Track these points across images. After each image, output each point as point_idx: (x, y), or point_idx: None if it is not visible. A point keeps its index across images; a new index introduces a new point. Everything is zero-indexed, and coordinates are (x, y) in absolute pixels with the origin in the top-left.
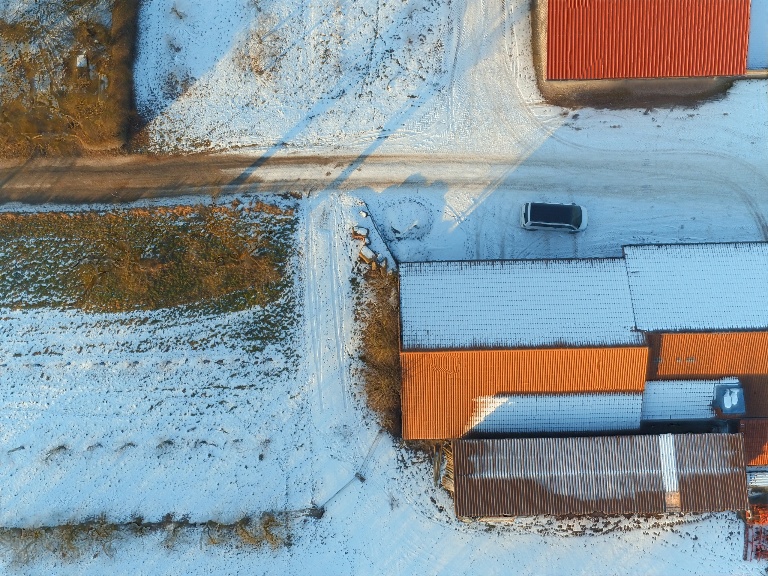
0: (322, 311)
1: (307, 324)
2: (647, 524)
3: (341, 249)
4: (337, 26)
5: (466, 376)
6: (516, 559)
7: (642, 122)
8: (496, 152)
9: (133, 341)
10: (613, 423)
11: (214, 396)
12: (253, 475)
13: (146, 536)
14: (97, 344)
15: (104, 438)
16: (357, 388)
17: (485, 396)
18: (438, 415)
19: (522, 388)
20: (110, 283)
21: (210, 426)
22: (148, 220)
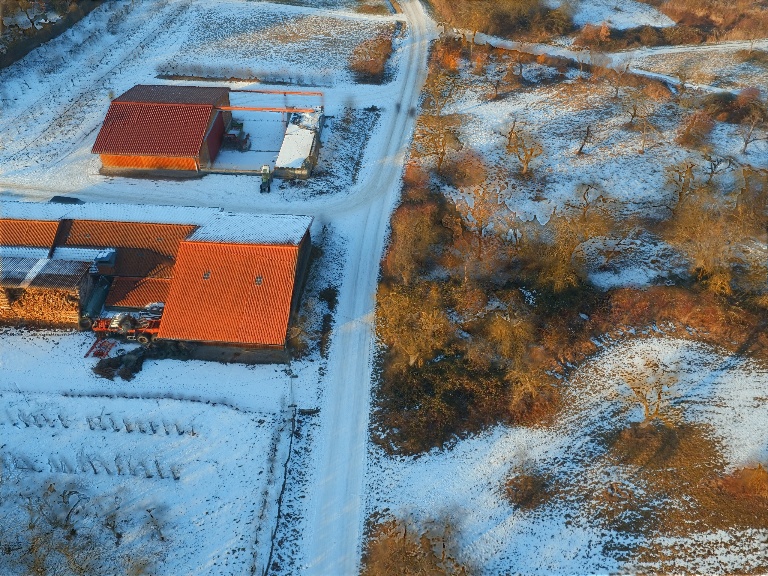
0: None
1: None
2: (28, 334)
3: None
4: (6, 144)
5: None
6: None
7: (149, 184)
8: (58, 188)
9: None
10: None
11: None
12: None
13: None
14: None
15: None
16: None
17: None
18: None
19: None
20: None
21: None
22: None
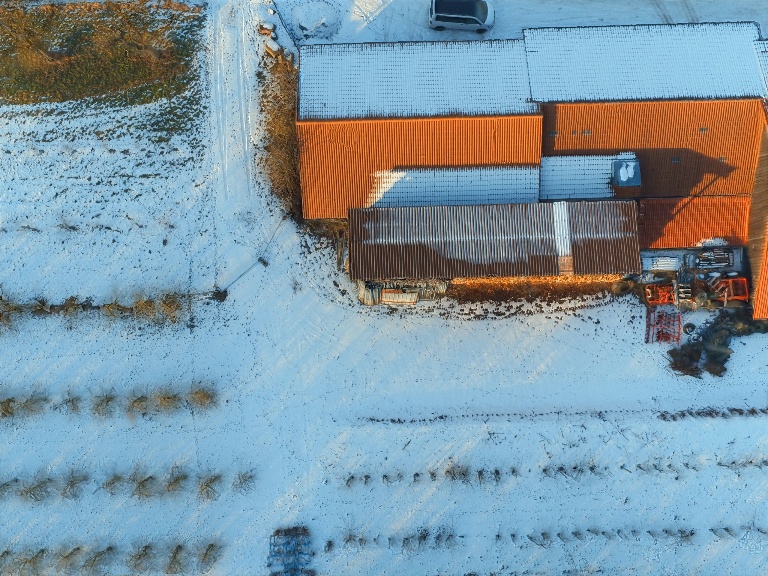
0: (228, 103)
1: (213, 116)
2: (550, 308)
3: (248, 44)
4: None
5: (363, 149)
6: (418, 341)
7: None
8: None
9: (39, 131)
10: (512, 200)
11: (119, 184)
12: (157, 259)
13: (49, 318)
14: (3, 134)
15: (9, 223)
16: (262, 176)
17: (383, 171)
18: (337, 192)
19: (419, 162)
20: (17, 75)
21: (115, 213)
22: (56, 15)
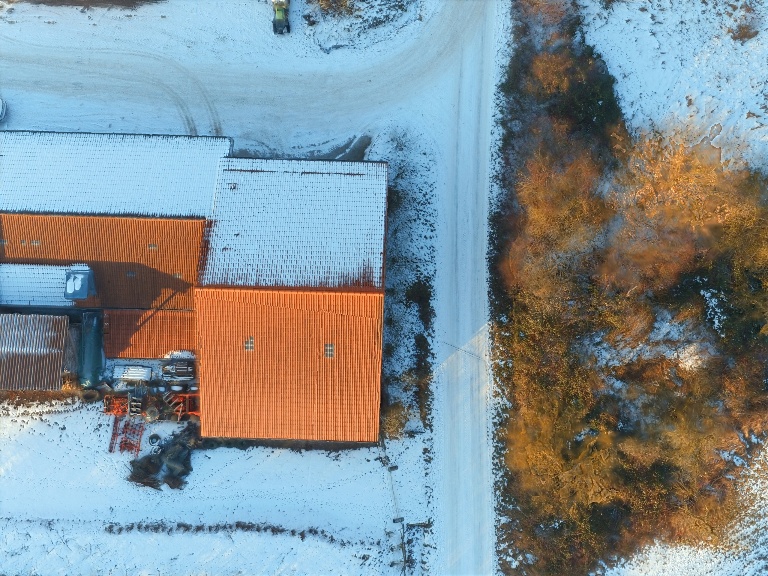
0: None
1: None
2: (17, 412)
3: None
4: None
5: None
6: None
7: (78, 20)
8: None
9: None
10: None
11: None
12: None
13: None
14: None
15: None
16: None
17: None
18: None
19: None
20: None
21: None
22: None
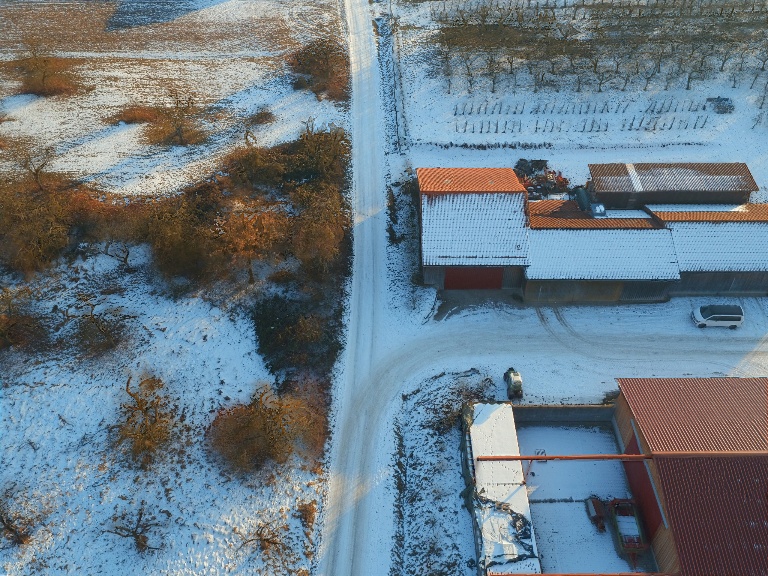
0: None
1: None
2: None
3: None
4: None
5: (762, 215)
6: None
7: None
8: None
9: None
10: None
11: None
12: None
13: None
14: None
15: None
16: None
17: None
18: None
19: None
20: None
21: None
22: None
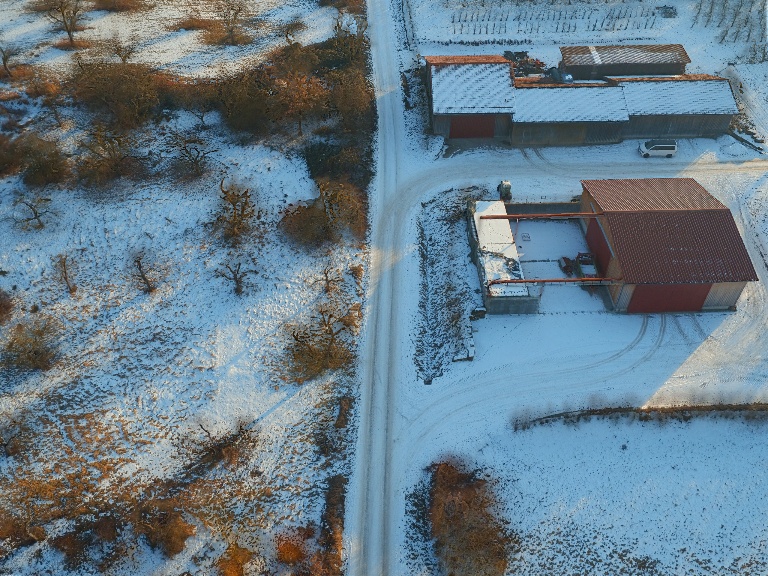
0: (763, 116)
1: None
2: None
3: (766, 135)
4: None
5: None
6: None
7: None
8: (699, 174)
9: None
10: None
11: None
12: (766, 72)
13: None
14: None
15: None
16: None
17: None
18: None
19: None
20: None
21: None
22: None
